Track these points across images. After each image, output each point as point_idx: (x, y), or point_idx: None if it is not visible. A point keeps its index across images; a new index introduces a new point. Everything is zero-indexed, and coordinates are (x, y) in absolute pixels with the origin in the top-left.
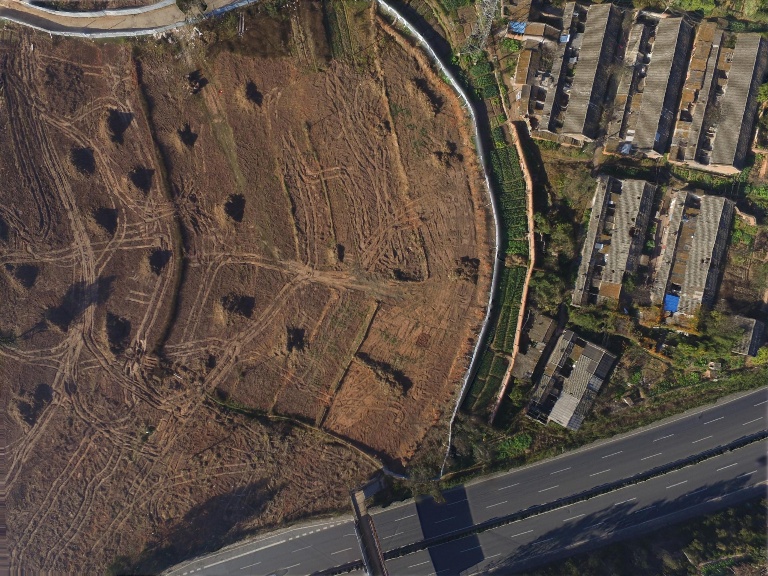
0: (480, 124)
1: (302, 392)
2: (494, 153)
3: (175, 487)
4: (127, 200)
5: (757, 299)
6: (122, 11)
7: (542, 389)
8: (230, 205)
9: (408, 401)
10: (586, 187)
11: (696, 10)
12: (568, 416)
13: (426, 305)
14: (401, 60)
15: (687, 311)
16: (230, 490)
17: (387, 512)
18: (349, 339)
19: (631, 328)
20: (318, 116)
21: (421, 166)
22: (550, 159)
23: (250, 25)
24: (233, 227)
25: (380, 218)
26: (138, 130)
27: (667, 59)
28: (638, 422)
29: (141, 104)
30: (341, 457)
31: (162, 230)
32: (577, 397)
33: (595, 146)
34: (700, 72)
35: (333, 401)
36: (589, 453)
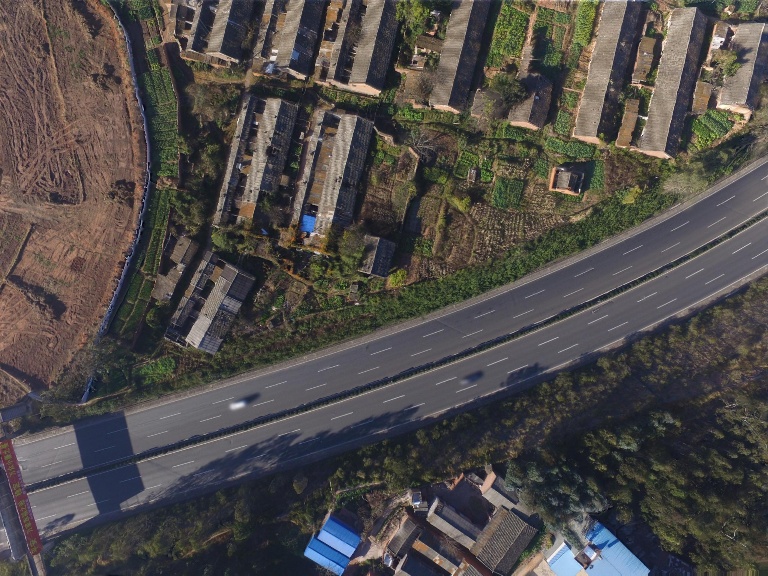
0: (136, 46)
1: None
2: (148, 75)
3: None
4: None
5: (396, 220)
6: None
7: (180, 311)
8: None
9: (62, 325)
10: (203, 101)
11: None
12: (200, 337)
13: (81, 228)
14: None
15: (320, 231)
16: None
17: (45, 440)
18: (6, 262)
19: (268, 249)
20: None
21: (79, 88)
22: (203, 81)
23: None
24: None
25: (38, 141)
26: None
27: None
28: (292, 349)
29: None
30: None
31: None
32: (210, 318)
33: (244, 67)
34: None
35: None
36: (252, 383)
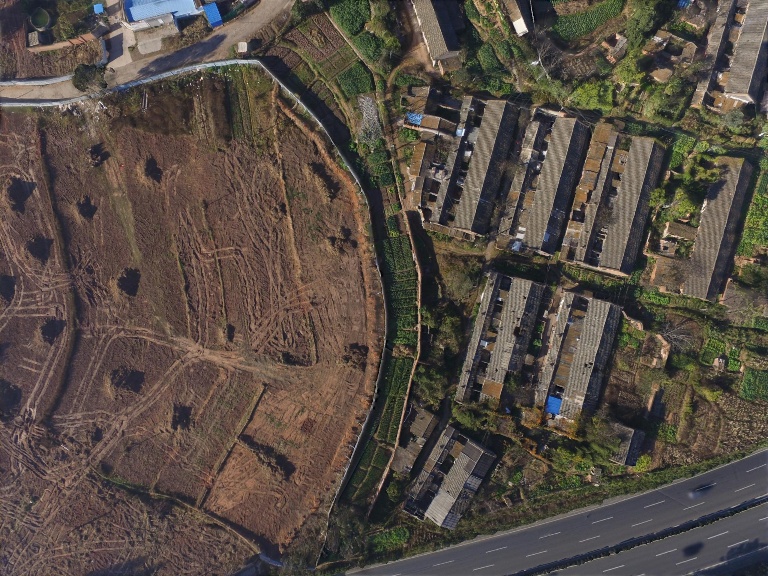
0: (375, 212)
1: (185, 471)
2: (387, 242)
3: (55, 559)
4: (25, 268)
5: (641, 406)
6: (29, 82)
7: (420, 485)
8: (124, 280)
9: (290, 486)
10: (466, 288)
11: (594, 109)
12: (443, 515)
13: (313, 390)
14: (300, 144)
15: (568, 415)
16: (107, 566)
17: None
18: (235, 420)
19: (512, 428)
20: (215, 195)
21: (315, 250)
22: (442, 251)
23: (153, 102)
24: (127, 301)
25: (272, 300)
26: (39, 199)
27: (560, 159)
28: (521, 520)
29: (43, 174)
30: (219, 539)
31: (58, 300)
32: (453, 496)
33: (487, 241)
34: (593, 173)
35: (215, 482)
36: (473, 547)
